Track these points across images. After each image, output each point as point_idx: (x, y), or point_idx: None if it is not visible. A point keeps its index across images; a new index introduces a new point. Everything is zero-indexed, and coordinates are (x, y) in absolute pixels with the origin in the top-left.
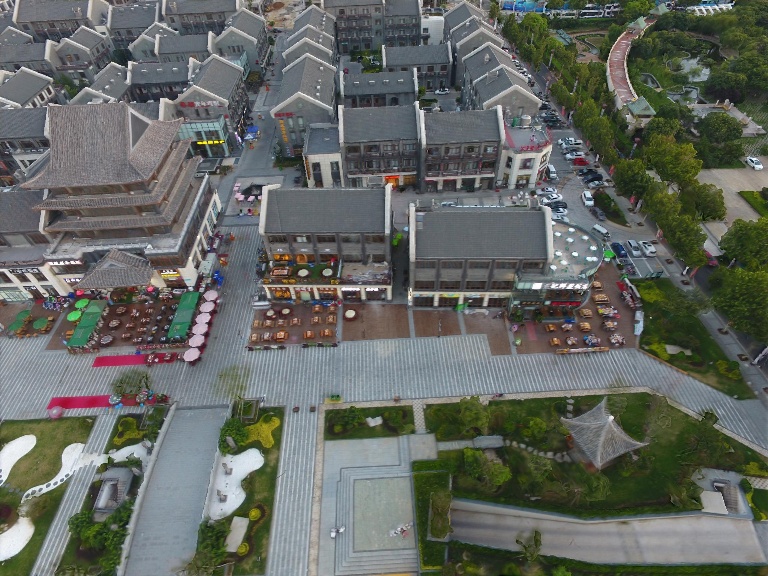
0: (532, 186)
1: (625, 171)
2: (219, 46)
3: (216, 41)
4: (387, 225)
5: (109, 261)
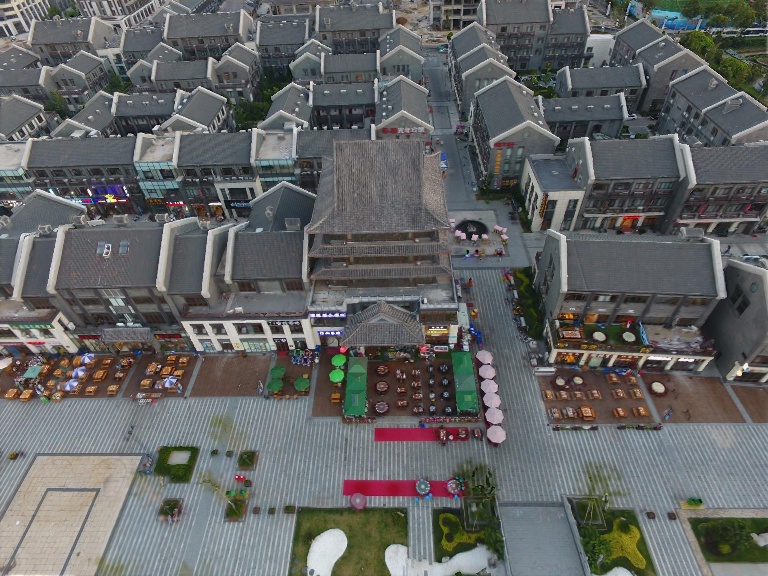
0: None
1: None
2: (384, 65)
3: (382, 60)
4: (722, 287)
5: (381, 316)
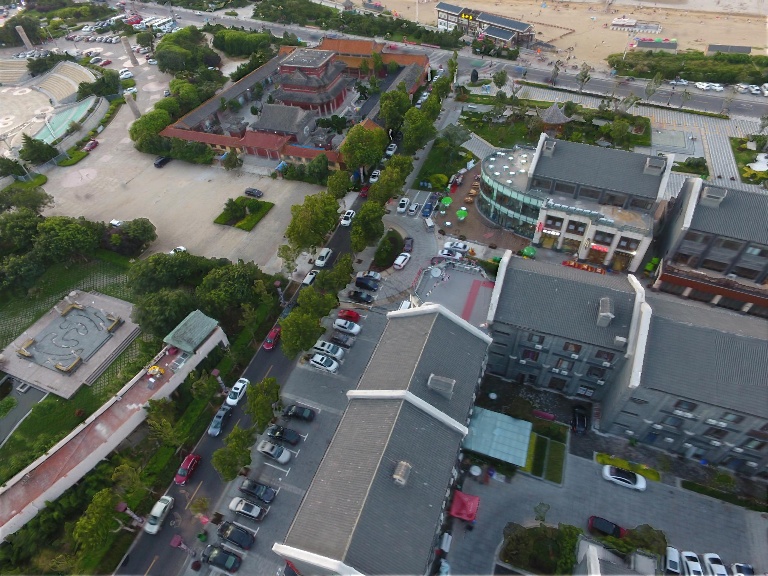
0: None
1: None
2: None
3: None
4: None
5: None
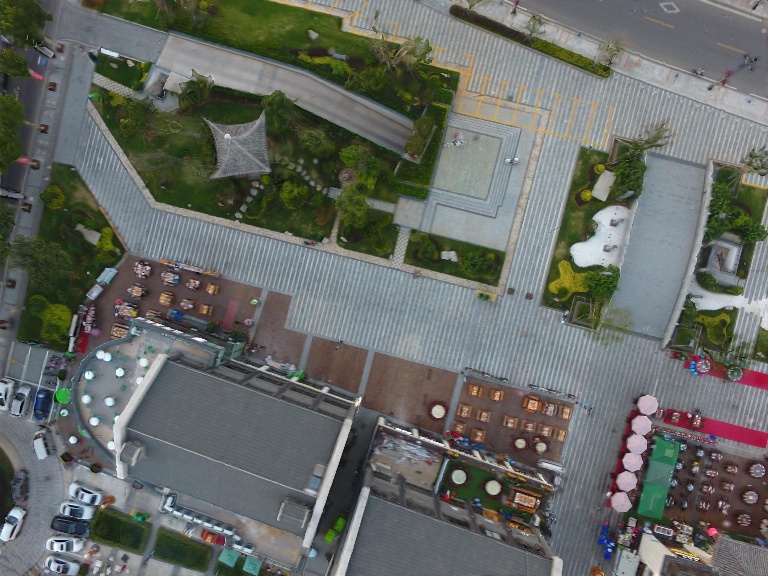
0: None
1: None
2: None
3: None
4: (363, 502)
5: None
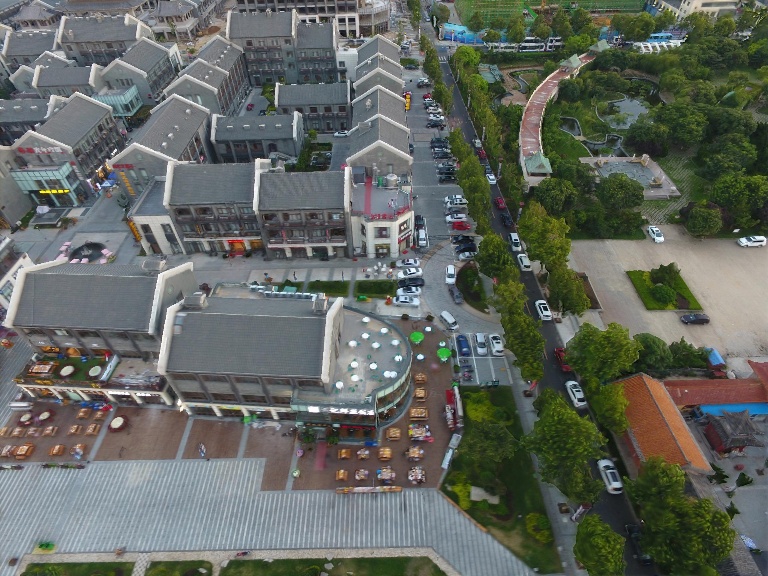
0: (395, 255)
1: (481, 250)
2: (106, 79)
3: (102, 74)
4: (151, 323)
5: None
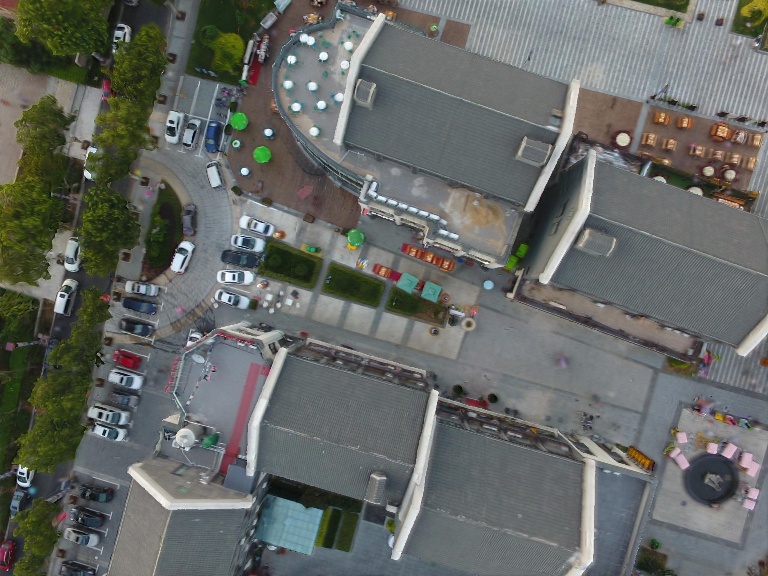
0: None
1: (118, 224)
2: None
3: None
4: (593, 159)
5: None
